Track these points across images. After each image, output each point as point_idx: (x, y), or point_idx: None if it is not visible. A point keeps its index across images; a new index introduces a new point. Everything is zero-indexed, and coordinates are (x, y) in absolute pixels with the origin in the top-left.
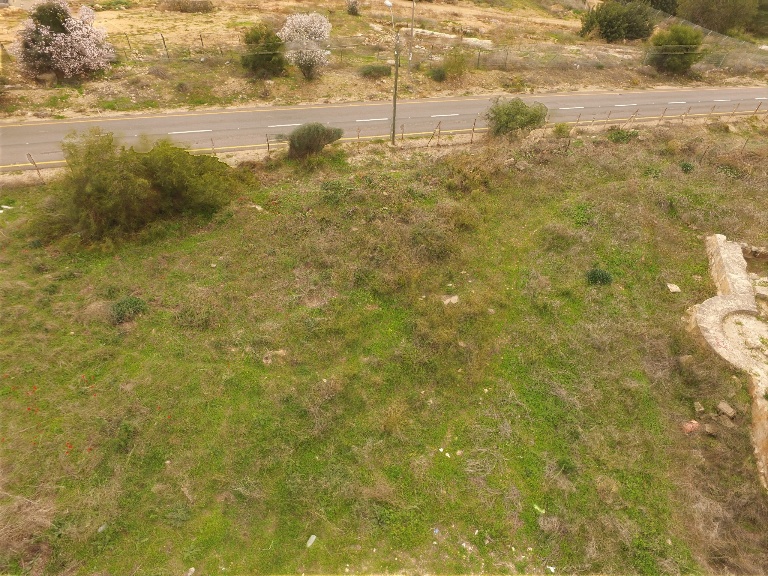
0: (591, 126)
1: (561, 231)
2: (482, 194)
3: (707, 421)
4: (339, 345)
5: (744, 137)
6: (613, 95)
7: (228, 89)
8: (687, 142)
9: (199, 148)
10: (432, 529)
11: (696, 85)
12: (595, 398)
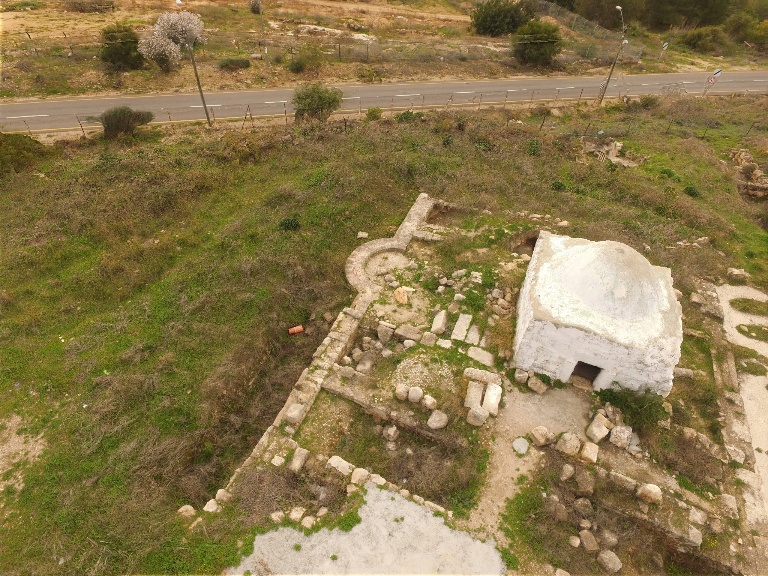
0: (413, 110)
1: (279, 190)
2: (248, 164)
3: (311, 326)
4: (34, 272)
5: (564, 120)
6: (459, 84)
7: (85, 80)
8: (462, 121)
9: (27, 130)
10: (14, 383)
11: (555, 75)
12: (200, 303)
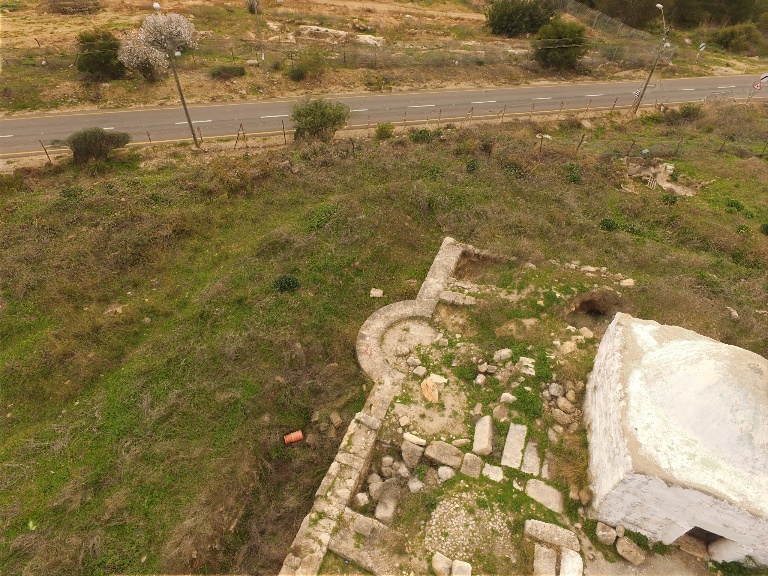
0: (428, 125)
1: (274, 236)
2: (239, 198)
3: (313, 431)
4: None
5: (597, 133)
6: (477, 92)
7: (59, 93)
8: (488, 141)
9: None
10: None
11: (580, 80)
12: (167, 410)
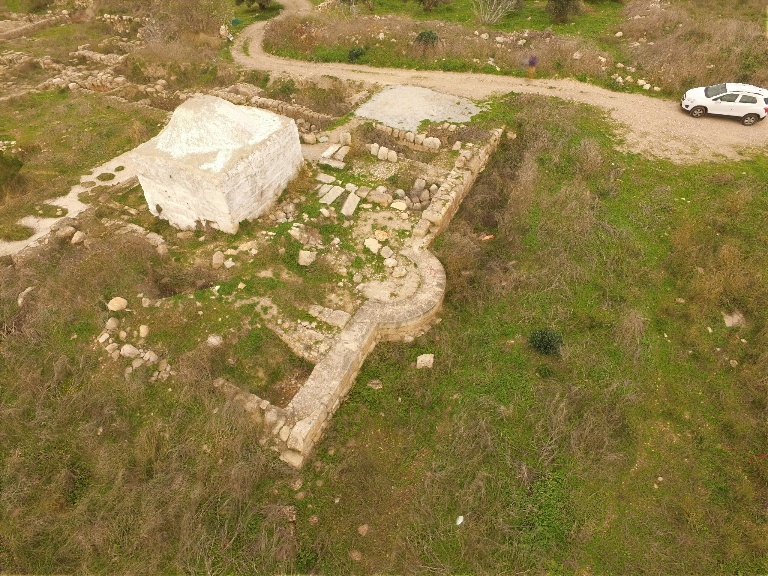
0: None
1: None
2: None
3: None
4: None
5: None
6: None
7: None
8: None
9: None
10: None
11: None
12: None
